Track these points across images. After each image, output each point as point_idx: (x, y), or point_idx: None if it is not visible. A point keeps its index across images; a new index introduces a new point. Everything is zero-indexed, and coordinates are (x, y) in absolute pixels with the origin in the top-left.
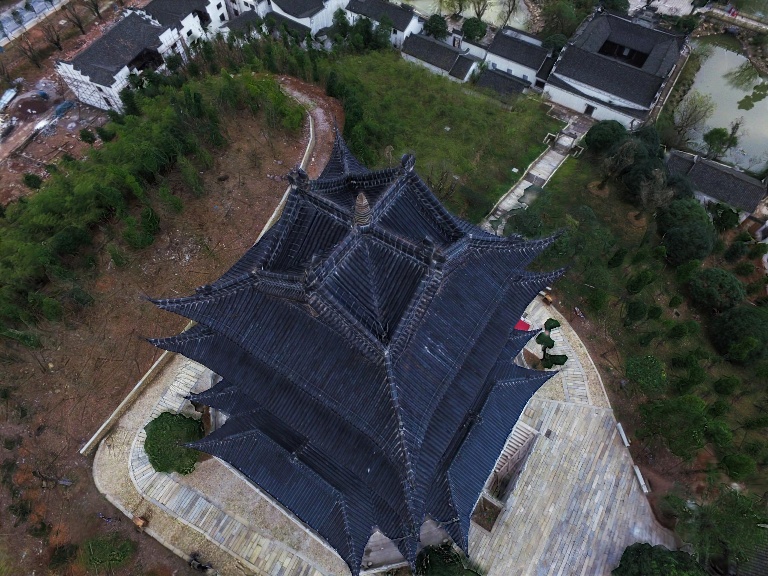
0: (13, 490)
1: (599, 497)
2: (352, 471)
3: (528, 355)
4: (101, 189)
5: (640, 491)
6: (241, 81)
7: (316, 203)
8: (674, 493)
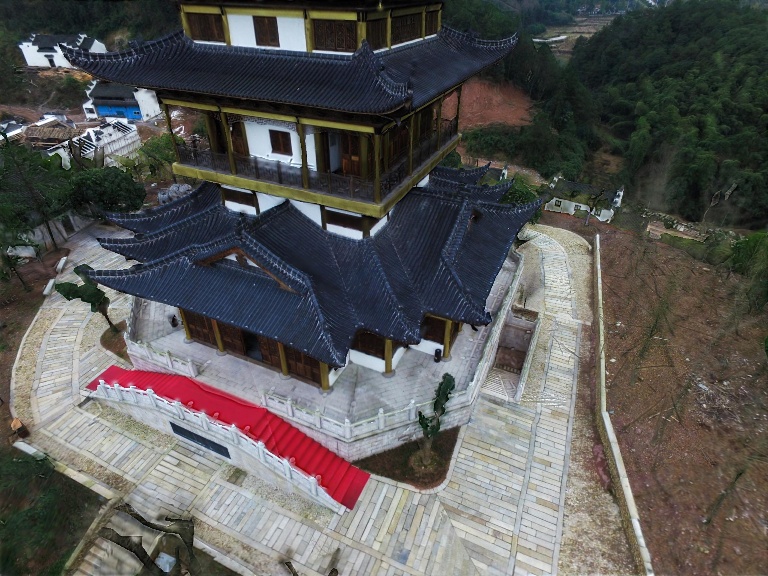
0: (619, 208)
1: (116, 255)
2: None
3: (117, 344)
4: None
5: (70, 261)
6: None
7: None
8: (34, 264)
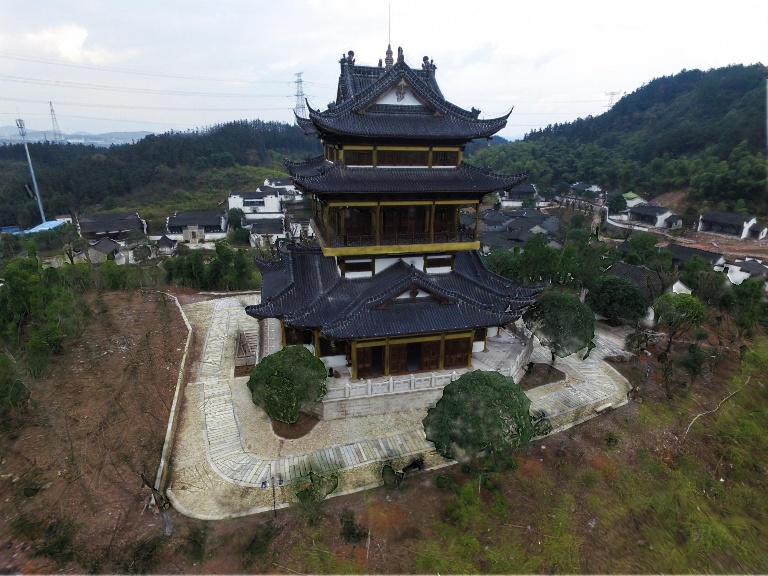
0: (89, 567)
1: None
2: (469, 189)
3: None
4: (11, 279)
5: None
6: (59, 269)
7: (359, 72)
8: None
